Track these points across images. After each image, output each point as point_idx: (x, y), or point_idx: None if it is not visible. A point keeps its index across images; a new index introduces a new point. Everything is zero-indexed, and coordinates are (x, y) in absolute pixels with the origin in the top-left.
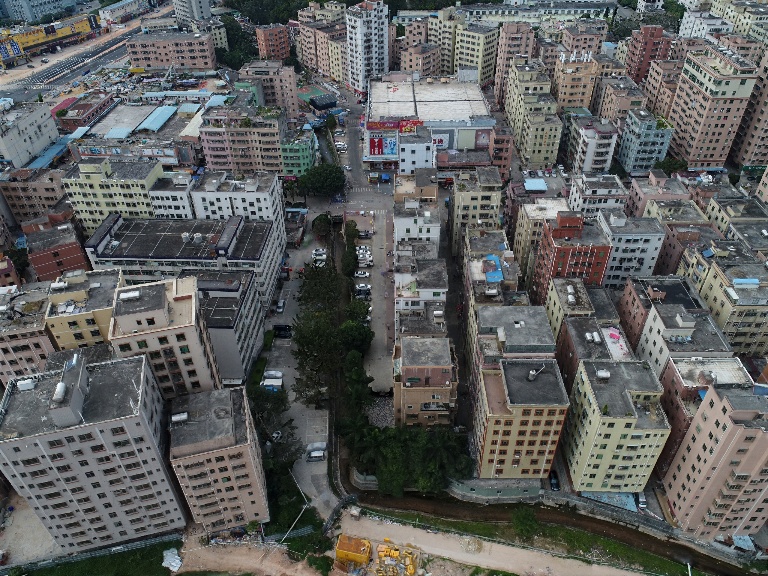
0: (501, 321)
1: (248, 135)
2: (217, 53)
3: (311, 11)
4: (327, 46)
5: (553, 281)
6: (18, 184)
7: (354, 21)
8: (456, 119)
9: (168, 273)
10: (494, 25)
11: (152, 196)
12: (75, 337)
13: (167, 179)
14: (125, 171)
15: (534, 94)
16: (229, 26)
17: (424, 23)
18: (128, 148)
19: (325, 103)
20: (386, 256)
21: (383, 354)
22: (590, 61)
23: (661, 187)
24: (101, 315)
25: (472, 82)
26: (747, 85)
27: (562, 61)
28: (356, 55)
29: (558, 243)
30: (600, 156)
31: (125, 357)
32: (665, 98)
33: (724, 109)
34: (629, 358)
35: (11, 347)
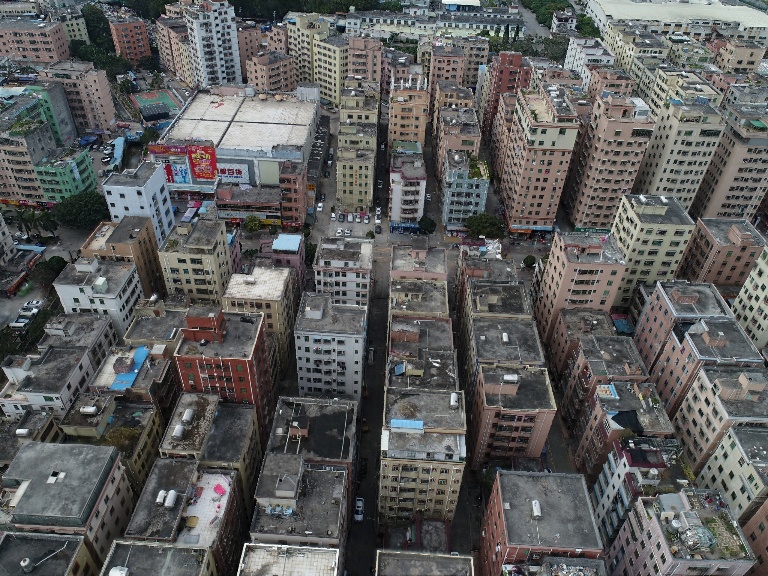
0: (35, 470)
1: None
2: (74, 46)
3: (180, 6)
4: (178, 47)
5: (180, 398)
6: None
7: (191, 22)
8: (263, 147)
9: None
10: (386, 35)
11: None
12: None
13: None
14: None
15: (353, 124)
16: (89, 17)
17: (284, 29)
18: None
19: (152, 113)
20: None
21: None
22: (426, 89)
23: (415, 261)
24: None
25: (312, 102)
26: (568, 135)
27: (391, 87)
28: (198, 61)
29: (187, 349)
30: (408, 204)
31: None
32: (504, 139)
33: (544, 161)
34: (217, 529)
35: None
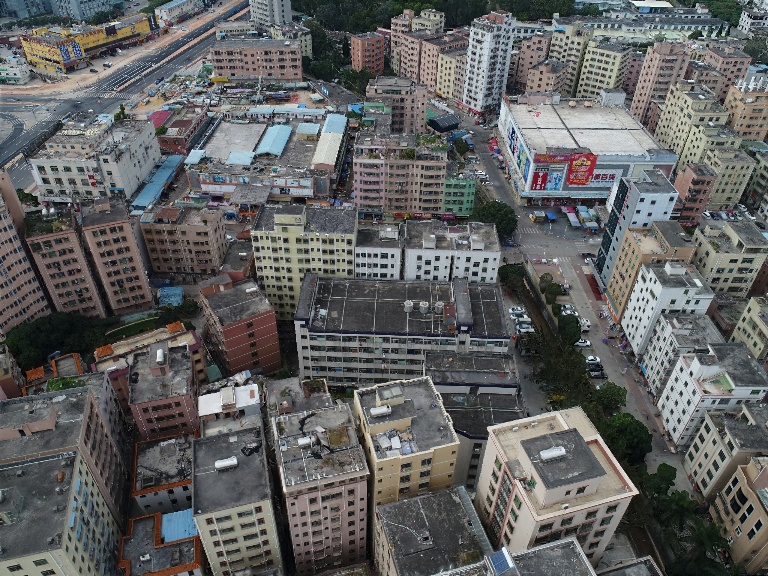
0: None
1: (410, 168)
2: (302, 62)
3: (406, 19)
4: (436, 59)
5: None
6: (165, 226)
7: (481, 35)
8: (626, 152)
9: (391, 351)
10: None
11: (357, 253)
12: (400, 480)
13: (368, 230)
14: (321, 221)
15: (714, 126)
16: (315, 33)
17: (546, 38)
18: (258, 177)
19: (448, 125)
20: (598, 318)
21: (656, 453)
22: None
23: None
24: (440, 452)
25: (618, 107)
26: None
27: (742, 90)
28: (478, 72)
29: None
30: None
31: (539, 537)
32: None
33: None
34: None
35: (321, 496)
